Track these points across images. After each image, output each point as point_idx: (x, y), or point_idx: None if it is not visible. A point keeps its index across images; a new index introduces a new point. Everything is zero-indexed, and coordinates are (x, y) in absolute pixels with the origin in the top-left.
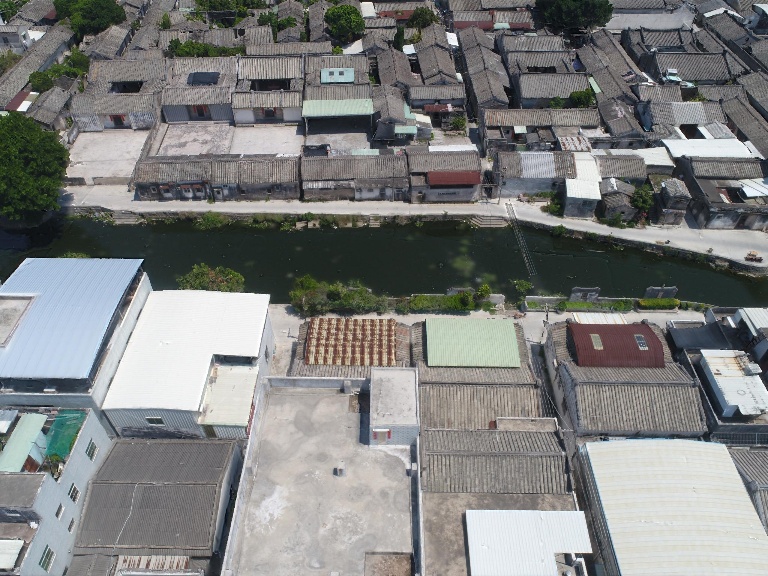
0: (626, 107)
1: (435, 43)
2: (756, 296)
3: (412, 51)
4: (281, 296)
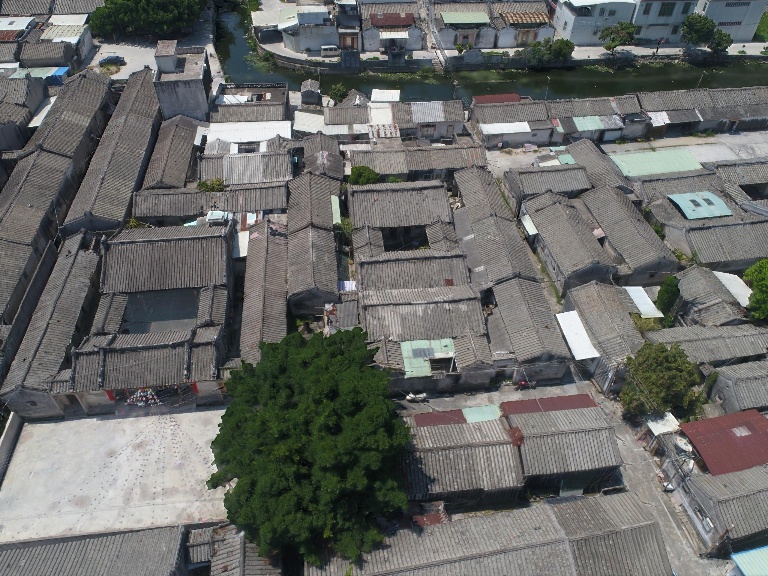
0: None
1: None
2: None
3: (633, 292)
4: (584, 71)
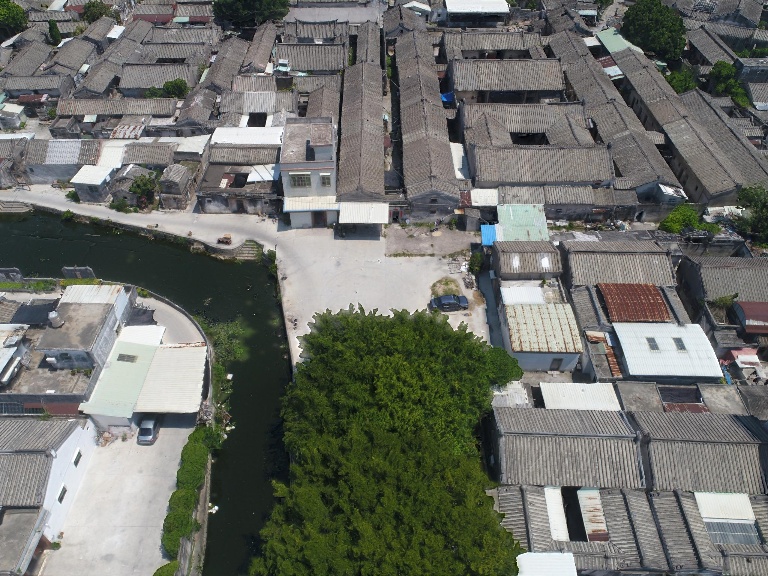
0: (212, 96)
1: (84, 36)
2: (227, 278)
3: None
4: None
